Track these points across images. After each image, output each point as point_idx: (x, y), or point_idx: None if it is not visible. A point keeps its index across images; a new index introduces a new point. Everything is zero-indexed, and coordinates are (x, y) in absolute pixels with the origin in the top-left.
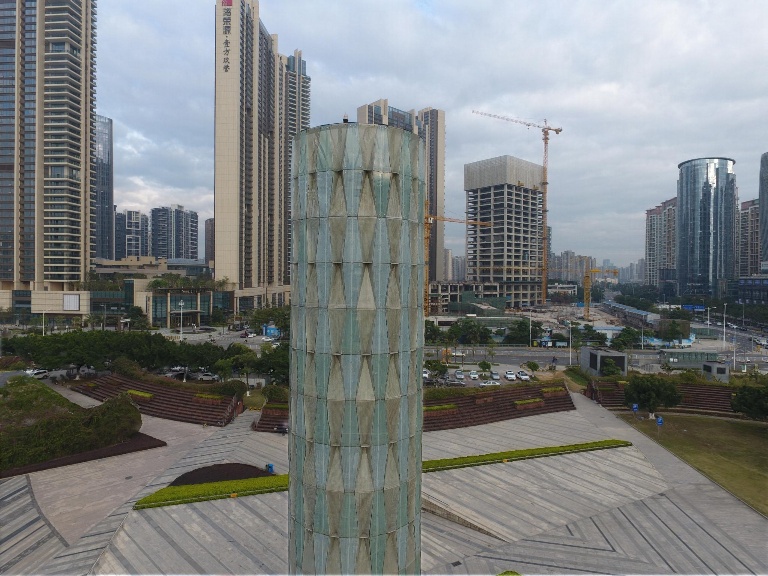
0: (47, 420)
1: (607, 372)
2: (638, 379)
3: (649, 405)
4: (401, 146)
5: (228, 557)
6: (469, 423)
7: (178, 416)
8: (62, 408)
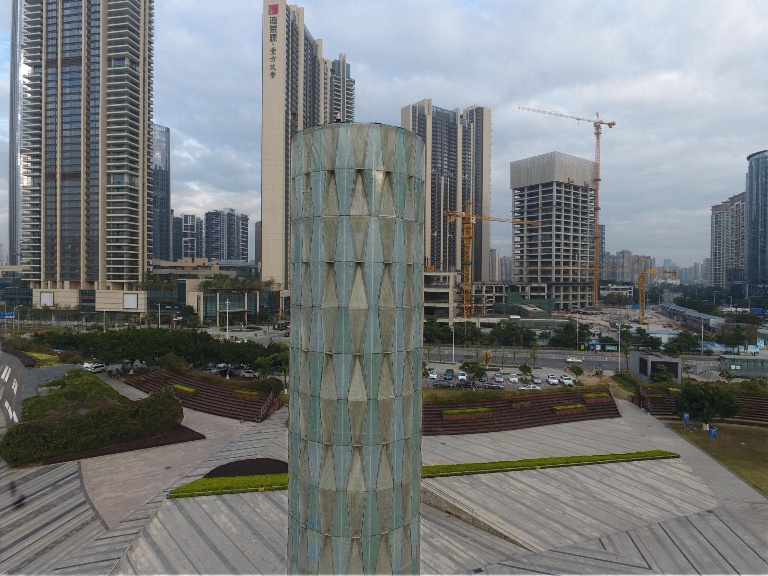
0: (97, 411)
1: (658, 378)
2: (690, 387)
3: (702, 415)
4: (395, 144)
5: (251, 549)
6: (504, 427)
7: (218, 411)
8: (112, 400)
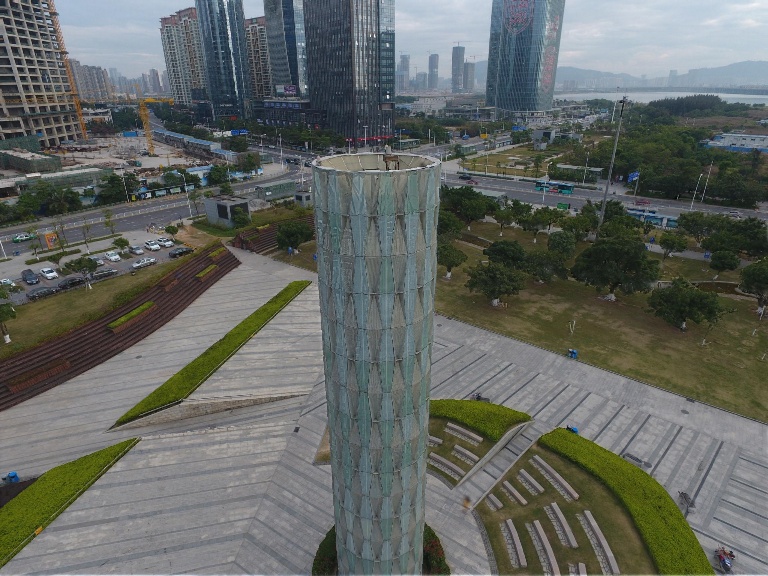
0: None
1: (239, 220)
2: (283, 226)
3: (297, 245)
4: None
5: (122, 575)
6: (174, 313)
7: None
8: None
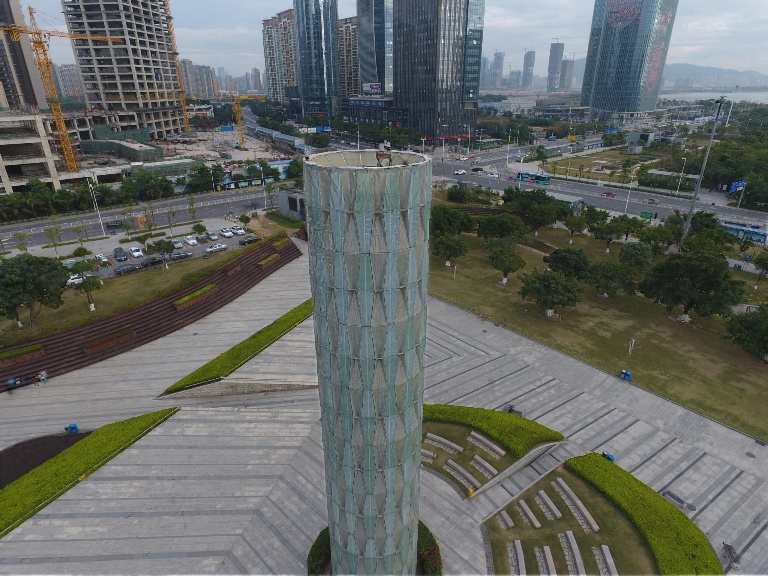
0: None
1: None
2: None
3: None
4: None
5: (143, 529)
6: (233, 297)
7: None
8: None
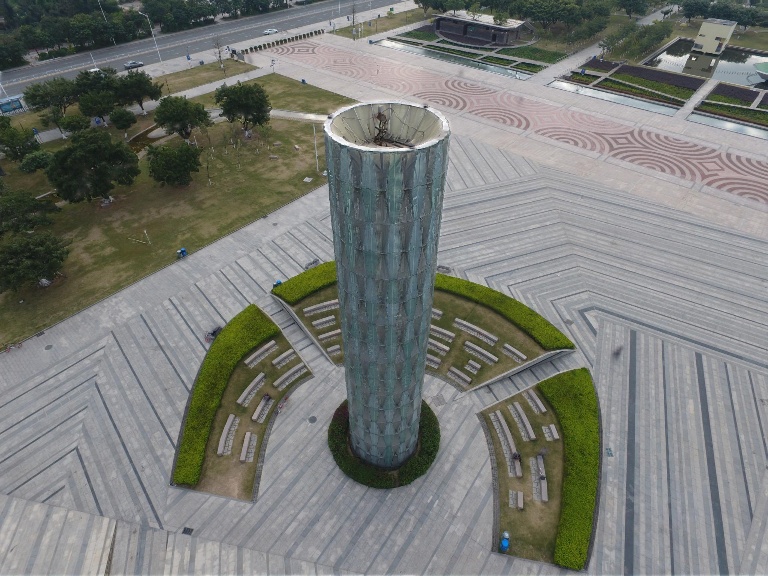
0: None
1: None
2: None
3: None
4: None
5: None
6: None
7: None
8: None
